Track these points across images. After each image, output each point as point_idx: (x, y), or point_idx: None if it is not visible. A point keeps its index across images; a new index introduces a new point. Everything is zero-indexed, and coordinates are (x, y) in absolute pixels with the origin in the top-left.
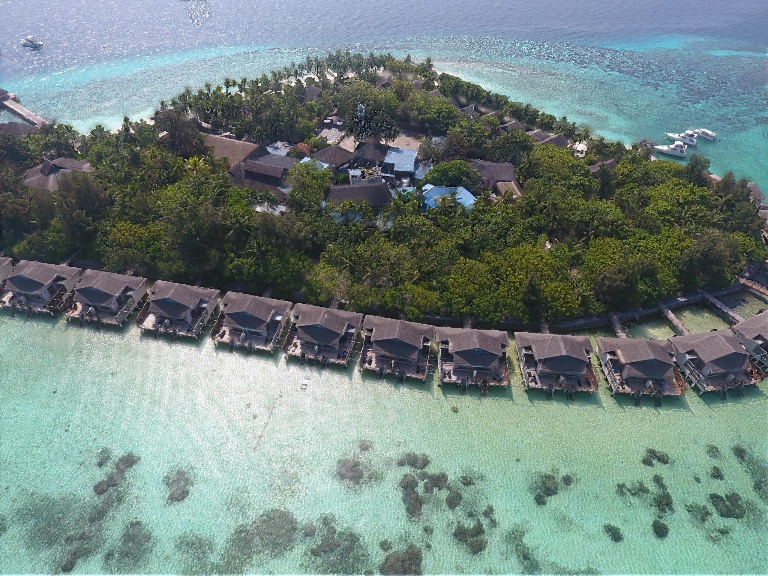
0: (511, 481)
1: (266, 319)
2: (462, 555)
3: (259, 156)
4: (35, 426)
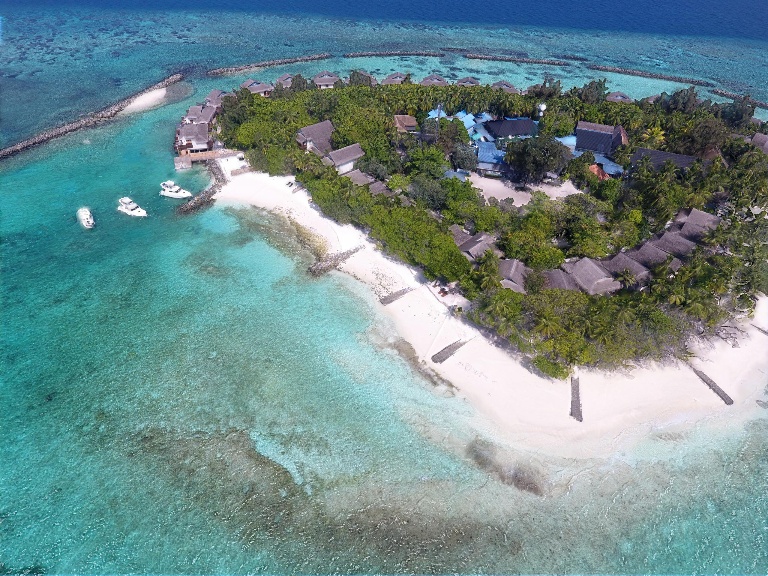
0: None
1: None
2: (439, 69)
3: None
4: None
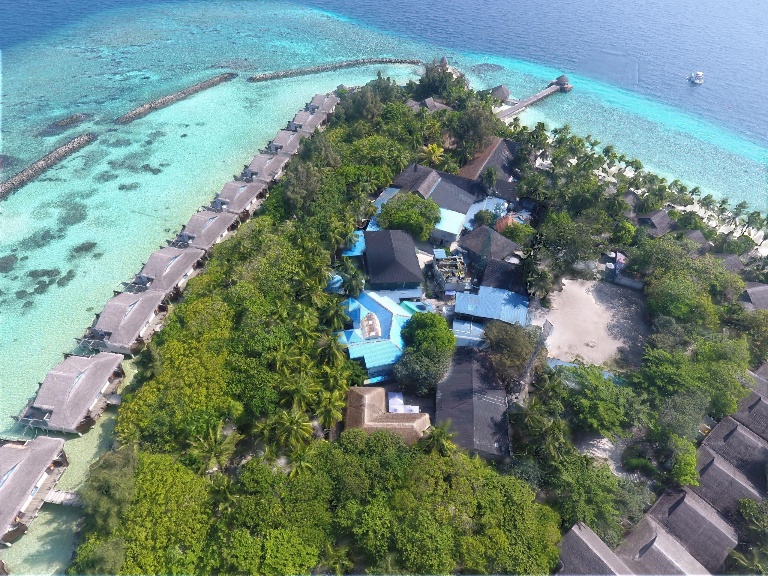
0: (4, 330)
1: (220, 197)
2: None
3: (460, 185)
4: (199, 145)
